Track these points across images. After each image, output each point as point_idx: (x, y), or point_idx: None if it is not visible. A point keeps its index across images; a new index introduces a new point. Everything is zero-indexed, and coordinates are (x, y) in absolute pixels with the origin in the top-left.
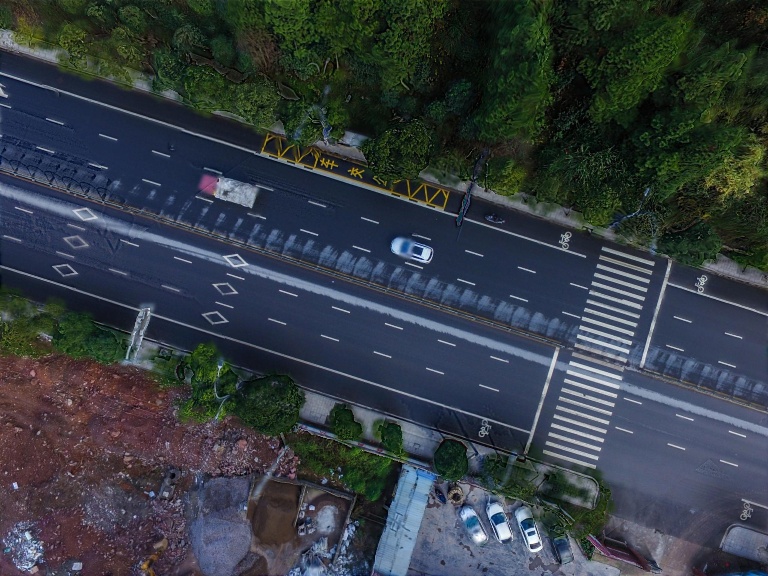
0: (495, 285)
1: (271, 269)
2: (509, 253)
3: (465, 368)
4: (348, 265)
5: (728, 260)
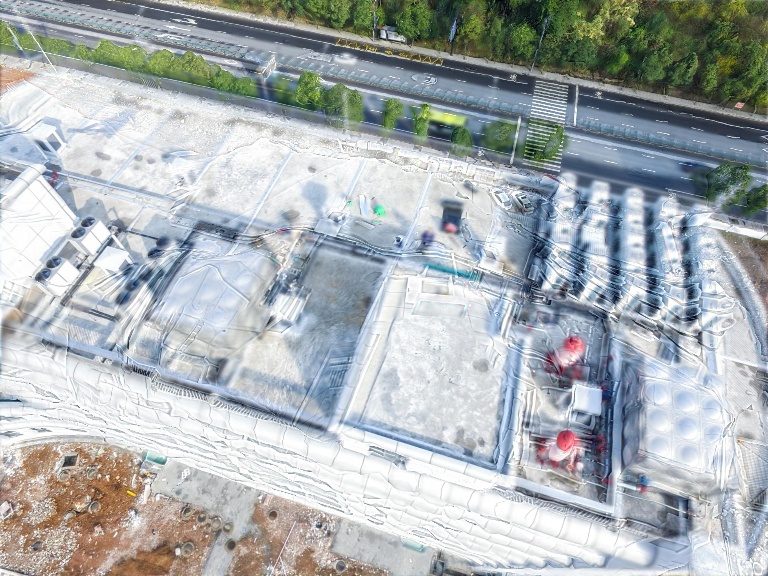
0: (476, 92)
1: None
2: (482, 81)
3: (463, 125)
4: (387, 83)
5: (610, 85)
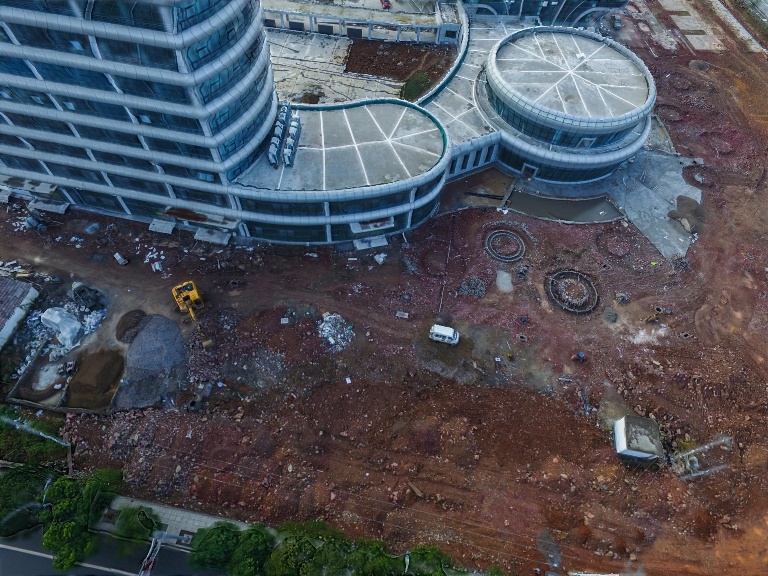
0: None
1: None
2: None
3: None
4: None
5: None
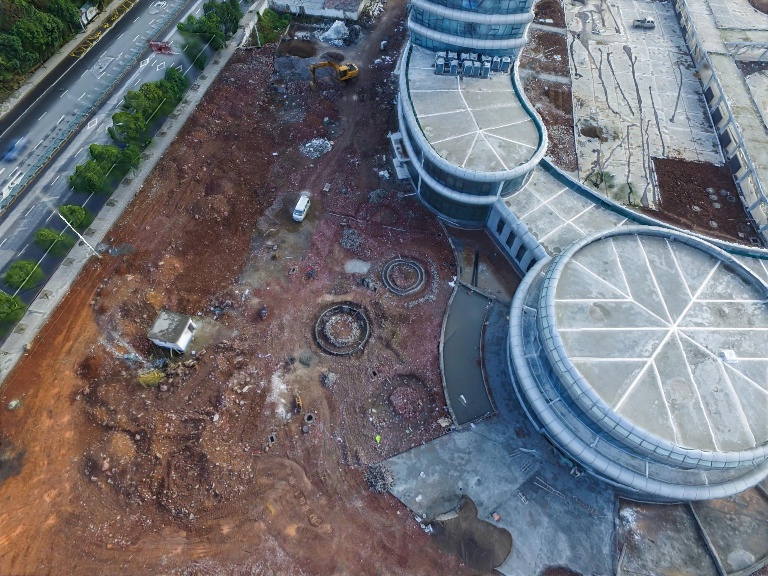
0: None
1: None
2: None
3: None
4: (159, 25)
5: None
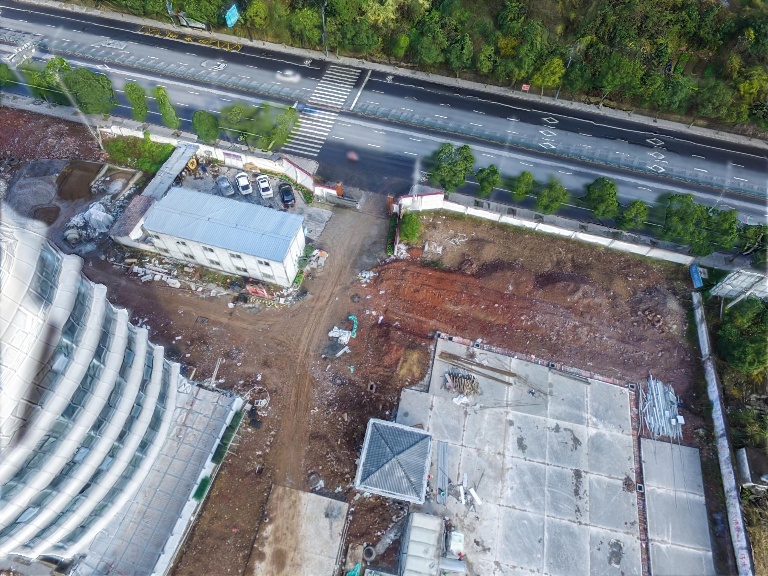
0: (262, 78)
1: (124, 71)
2: (273, 67)
3: None
4: (172, 69)
5: (405, 69)
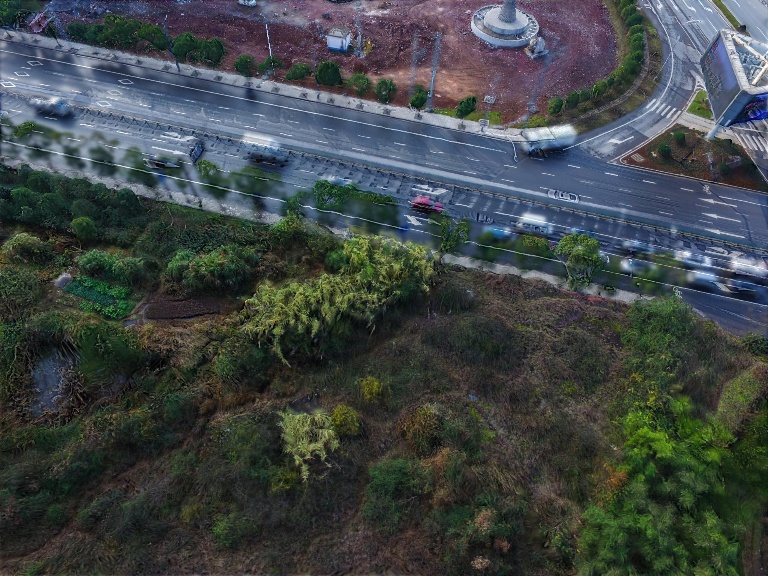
0: None
1: None
2: None
3: None
4: None
5: None
